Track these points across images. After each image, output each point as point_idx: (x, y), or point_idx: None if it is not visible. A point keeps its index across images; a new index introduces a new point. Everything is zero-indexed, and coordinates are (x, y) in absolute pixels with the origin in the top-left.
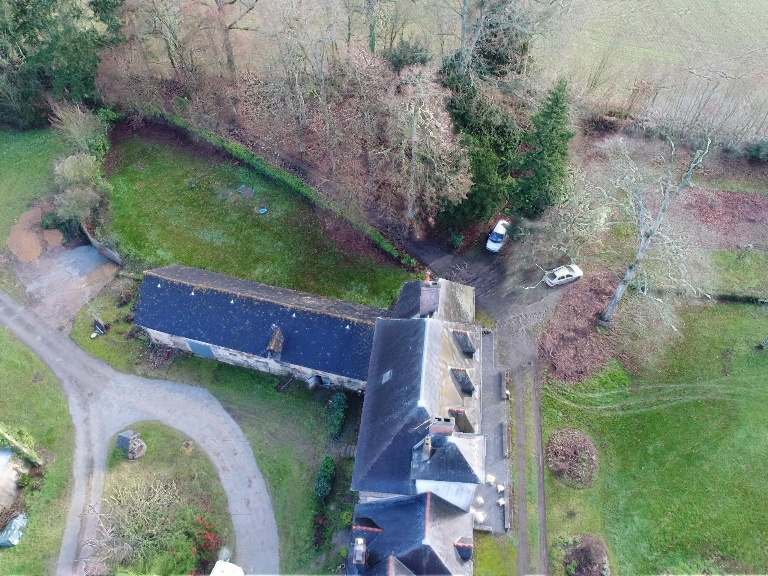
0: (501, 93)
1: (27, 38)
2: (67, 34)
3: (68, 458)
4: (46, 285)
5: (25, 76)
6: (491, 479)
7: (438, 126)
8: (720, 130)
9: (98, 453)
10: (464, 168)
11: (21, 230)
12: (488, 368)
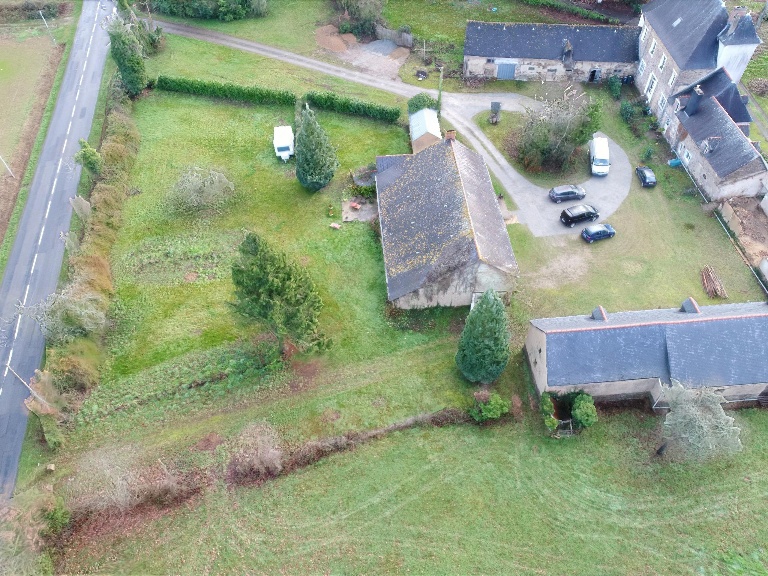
0: None
1: None
2: None
3: (452, 128)
4: (365, 61)
5: None
6: None
7: None
8: None
9: (469, 125)
10: None
11: (324, 36)
12: None
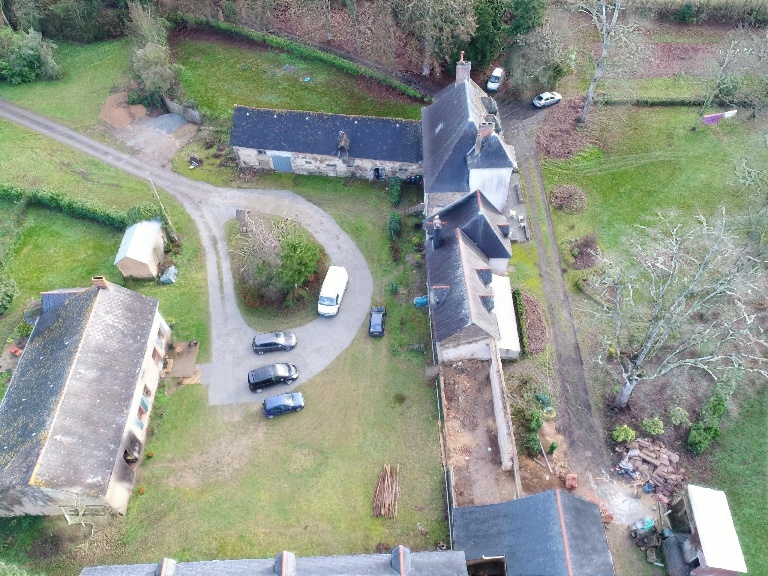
0: None
1: None
2: None
3: (195, 237)
4: (142, 141)
5: None
6: (513, 213)
7: None
8: (655, 2)
9: (217, 232)
10: (470, 13)
11: (110, 107)
12: None
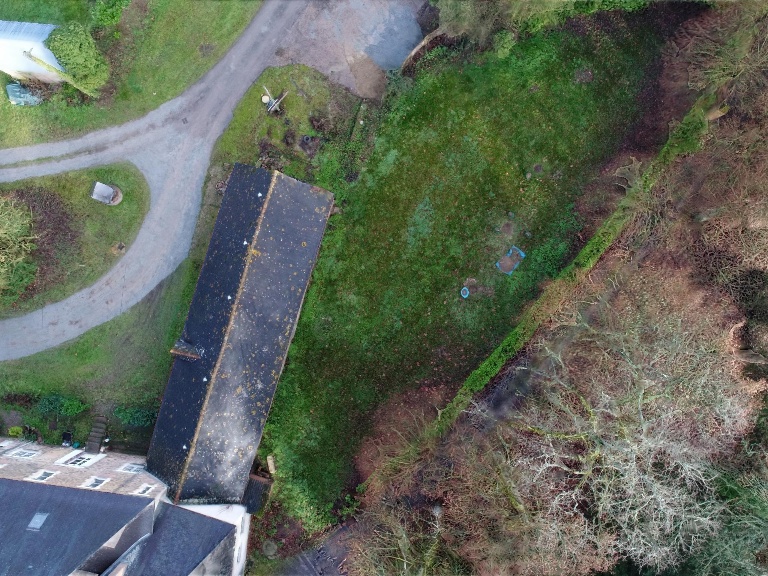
0: None
1: None
2: None
3: (105, 122)
4: (351, 6)
5: None
6: None
7: None
8: None
9: (112, 153)
10: None
11: None
12: None
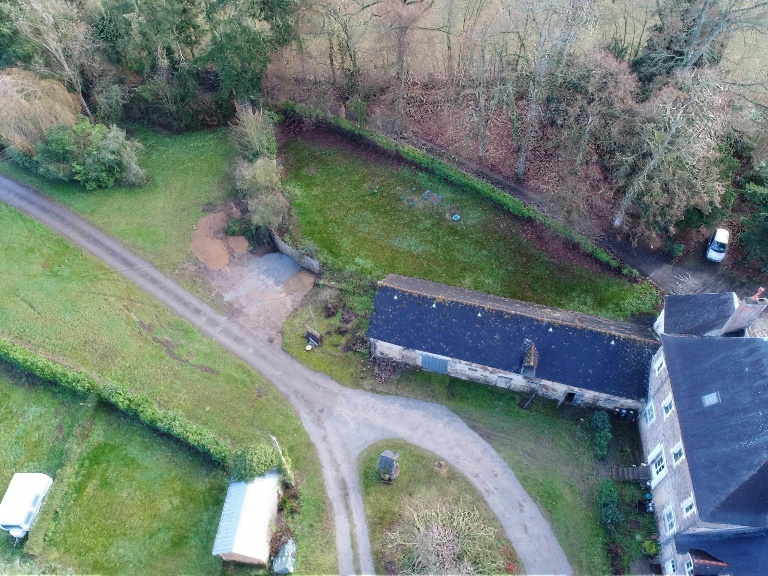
0: (729, 96)
1: (182, 38)
2: (242, 34)
3: (318, 479)
4: (243, 294)
5: (184, 77)
6: None
7: (690, 131)
8: None
9: (348, 473)
10: (716, 175)
11: (204, 236)
12: None
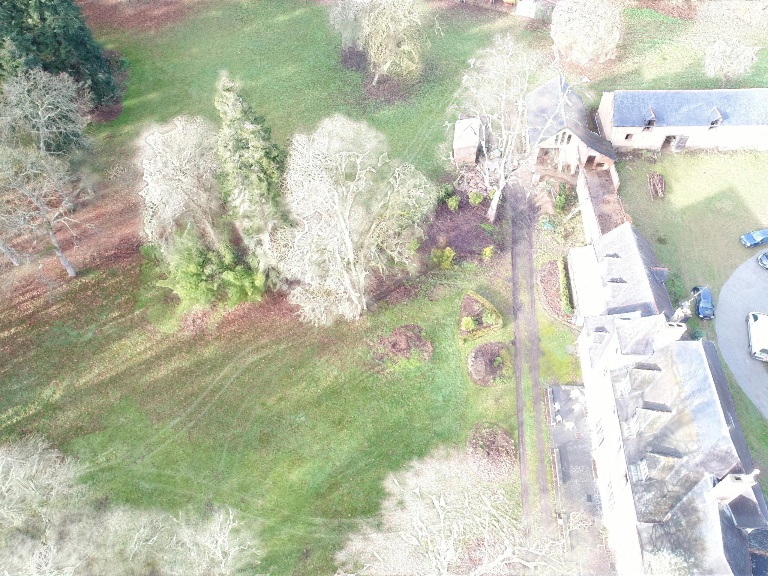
0: None
1: None
2: None
3: None
4: None
5: None
6: (569, 424)
7: None
8: None
9: None
10: None
11: None
12: (587, 557)
